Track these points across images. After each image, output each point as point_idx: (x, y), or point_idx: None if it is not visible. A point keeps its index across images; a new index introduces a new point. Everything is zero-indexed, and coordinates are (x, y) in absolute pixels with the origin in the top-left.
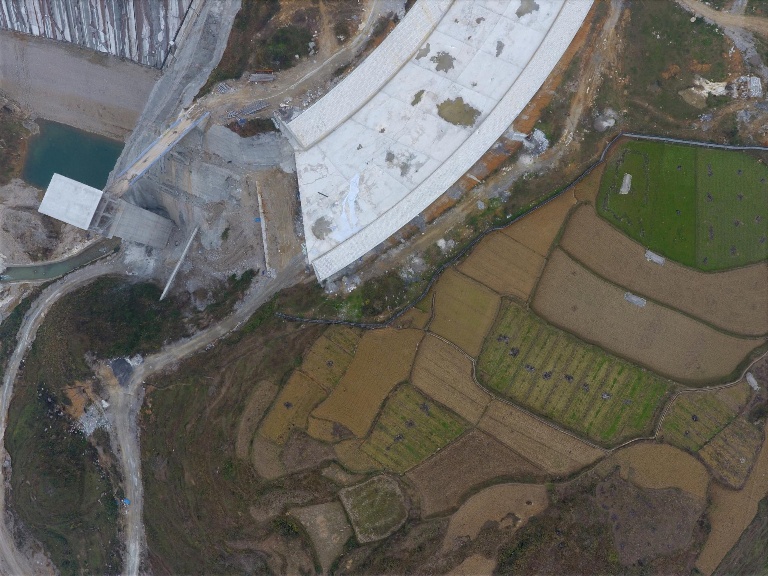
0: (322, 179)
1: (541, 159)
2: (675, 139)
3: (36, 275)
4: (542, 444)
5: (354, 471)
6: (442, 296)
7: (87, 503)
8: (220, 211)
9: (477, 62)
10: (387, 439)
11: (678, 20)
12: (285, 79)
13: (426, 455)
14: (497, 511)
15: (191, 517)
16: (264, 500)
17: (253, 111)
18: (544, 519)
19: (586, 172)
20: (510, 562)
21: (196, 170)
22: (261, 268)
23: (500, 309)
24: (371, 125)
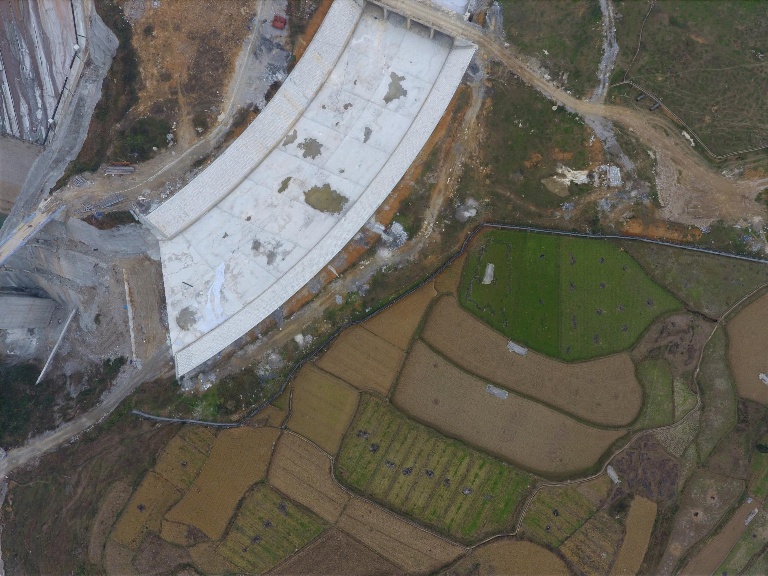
0: (187, 268)
1: (400, 252)
2: (536, 229)
3: None
4: (402, 543)
5: (209, 575)
6: (300, 392)
7: None
8: (93, 295)
9: (344, 148)
10: (244, 541)
11: (540, 108)
12: (143, 171)
13: (283, 556)
14: None
15: None
16: None
17: (109, 204)
18: None
19: (445, 264)
20: None
21: (64, 257)
22: (129, 357)
23: (360, 404)
24: (237, 213)
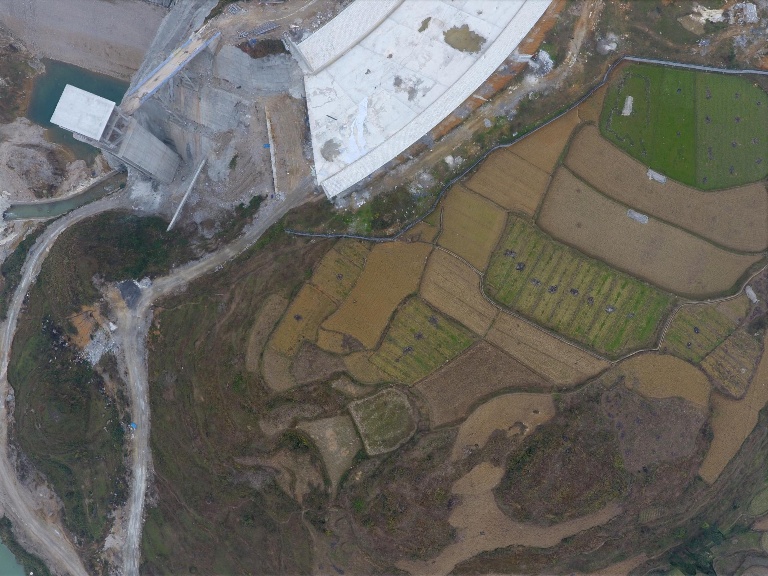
0: (331, 102)
1: (546, 79)
2: (675, 62)
3: (40, 213)
4: (548, 356)
5: (364, 383)
6: (450, 211)
7: (93, 431)
8: (228, 140)
9: None
10: (396, 351)
11: None
12: (295, 1)
13: (435, 367)
14: (505, 420)
15: (200, 434)
16: (274, 414)
17: (264, 31)
18: (551, 426)
19: (589, 92)
20: (518, 468)
21: (205, 96)
22: (270, 192)
23: (507, 225)
24: (379, 51)
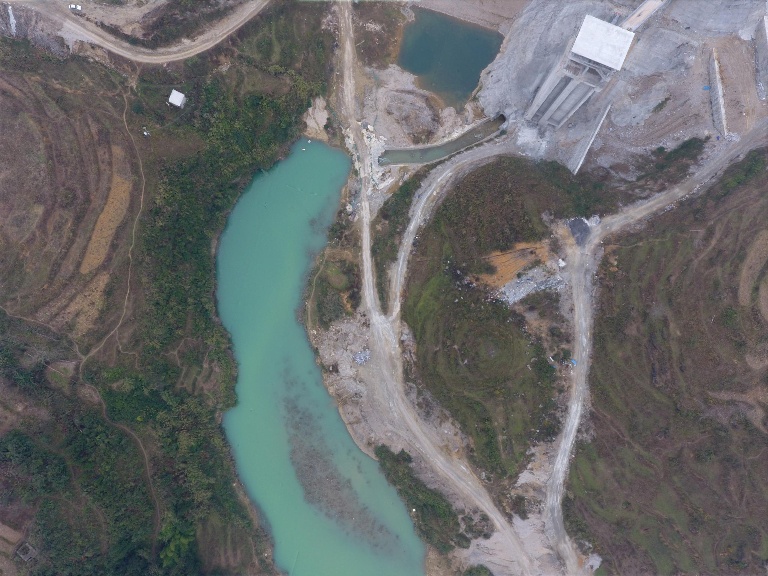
0: None
1: None
2: None
3: (413, 159)
4: None
5: None
6: None
7: (516, 368)
8: (652, 83)
9: None
10: None
11: None
12: None
13: None
14: None
15: (672, 368)
16: (760, 349)
17: None
18: None
19: None
20: None
21: (646, 38)
22: (715, 134)
23: None
24: None
